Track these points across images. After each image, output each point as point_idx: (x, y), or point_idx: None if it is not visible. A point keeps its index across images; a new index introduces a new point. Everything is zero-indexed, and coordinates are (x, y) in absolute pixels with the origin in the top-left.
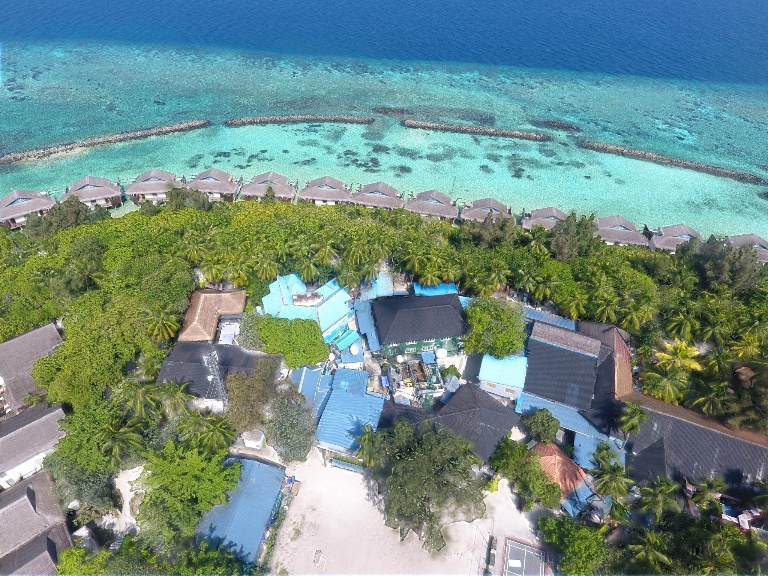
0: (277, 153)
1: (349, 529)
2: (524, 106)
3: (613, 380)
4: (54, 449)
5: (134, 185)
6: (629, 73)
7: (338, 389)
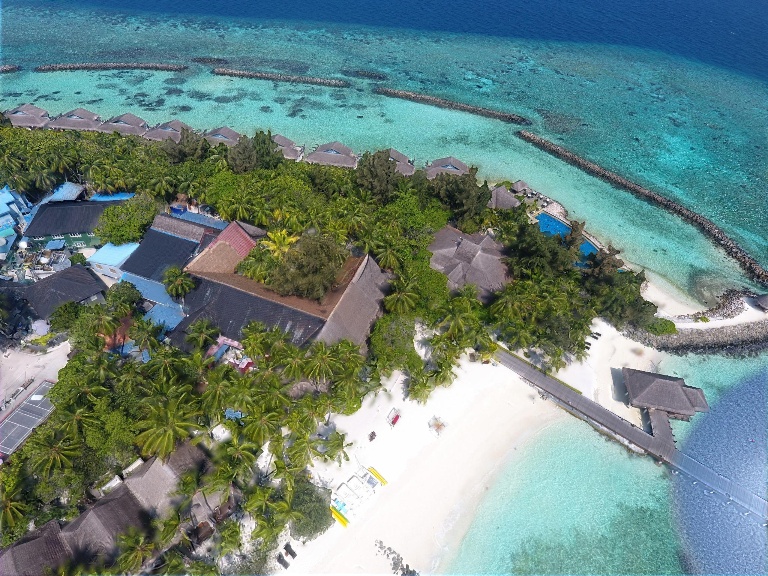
0: (68, 94)
1: None
2: (347, 58)
3: (194, 258)
4: None
5: None
6: (474, 32)
7: None
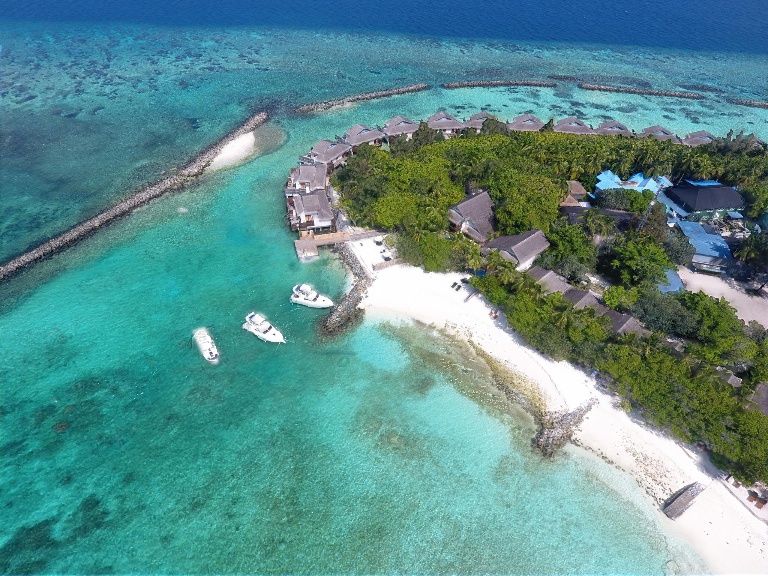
0: (500, 107)
1: (731, 301)
2: (667, 75)
3: None
4: (544, 253)
5: (431, 123)
6: (737, 50)
7: (686, 230)
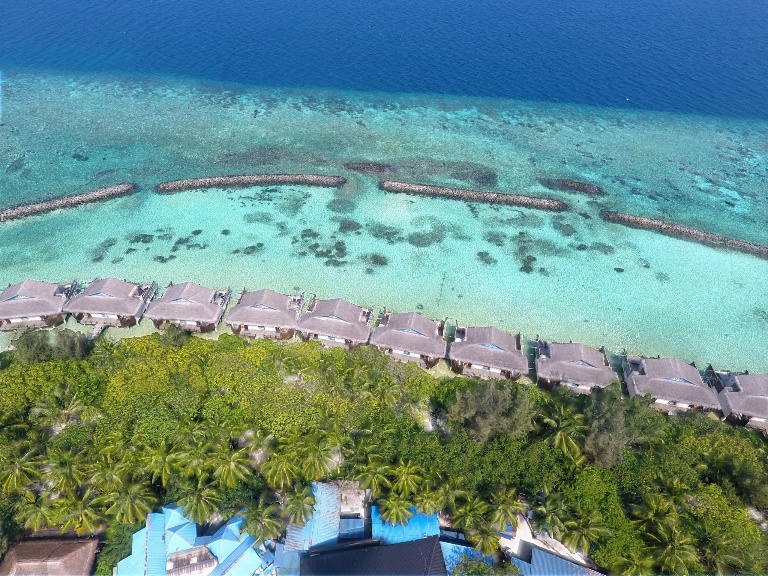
0: (214, 235)
1: None
2: (532, 157)
3: None
4: None
5: None
6: (655, 109)
7: None
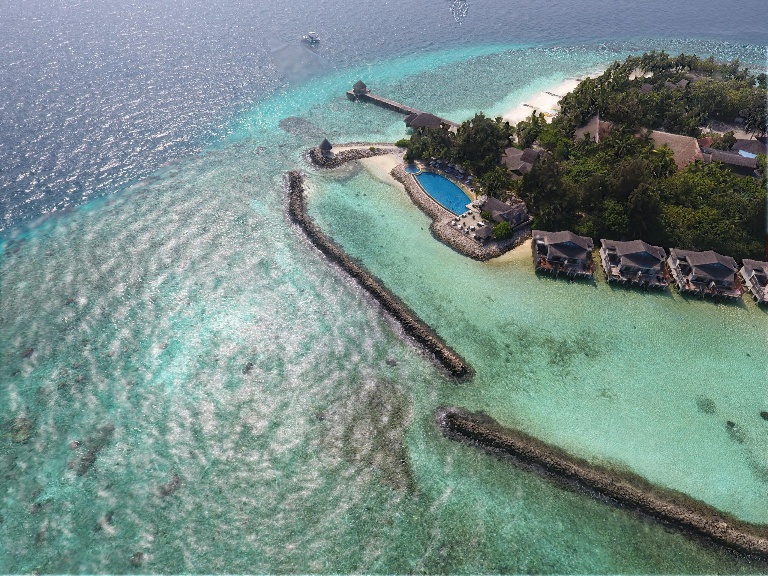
0: None
1: None
2: None
3: None
4: None
5: None
6: None
7: None
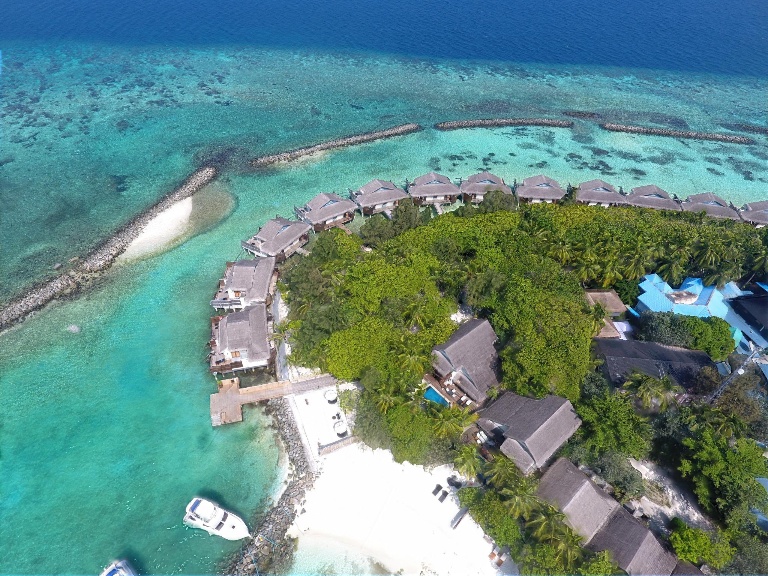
0: (506, 156)
1: None
2: (704, 109)
3: None
4: (572, 438)
5: (418, 188)
6: None
7: None
